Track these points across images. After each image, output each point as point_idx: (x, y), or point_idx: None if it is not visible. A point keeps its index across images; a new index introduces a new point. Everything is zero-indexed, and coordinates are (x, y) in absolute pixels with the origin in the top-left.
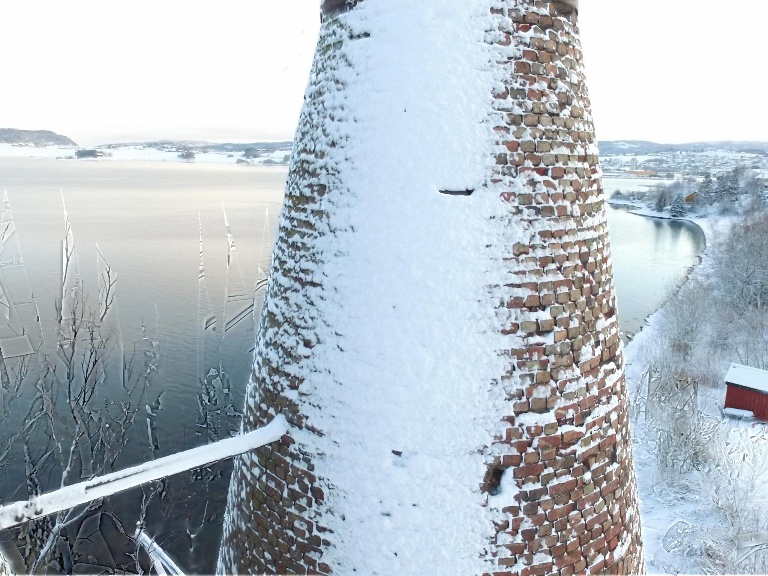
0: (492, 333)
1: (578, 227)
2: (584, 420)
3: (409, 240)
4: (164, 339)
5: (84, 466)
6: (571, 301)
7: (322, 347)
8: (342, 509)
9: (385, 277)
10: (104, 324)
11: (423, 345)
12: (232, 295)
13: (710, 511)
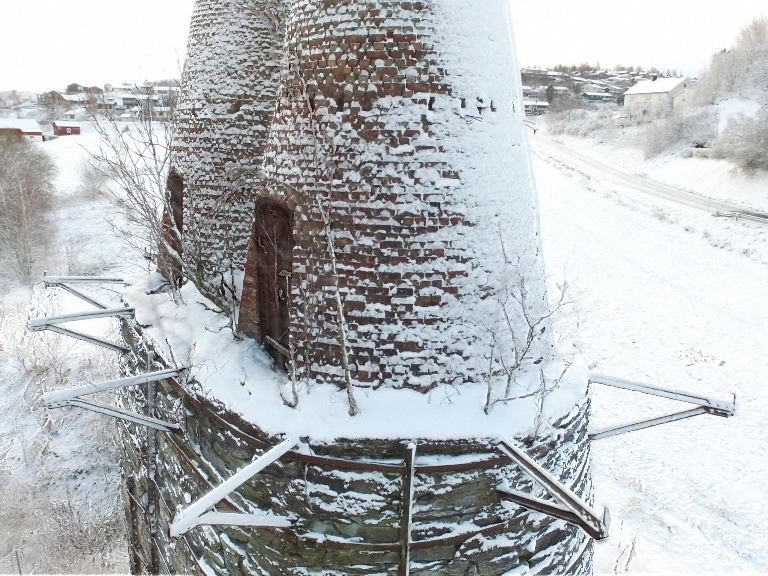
0: None
1: None
2: None
3: None
4: None
5: None
6: None
7: None
8: None
9: None
10: None
11: None
12: None
13: (21, 380)
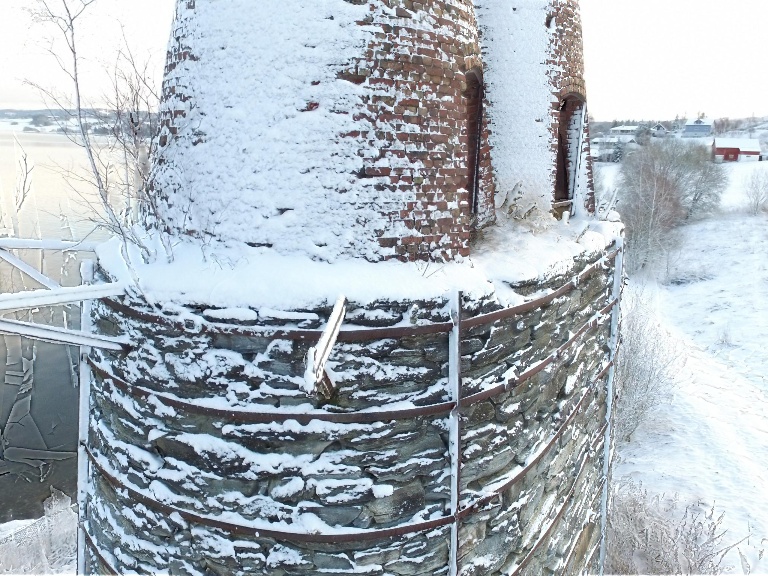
0: None
1: None
2: (574, 10)
3: None
4: (76, 233)
5: (9, 353)
6: None
7: None
8: (492, 36)
9: None
10: (22, 212)
11: None
12: None
13: None
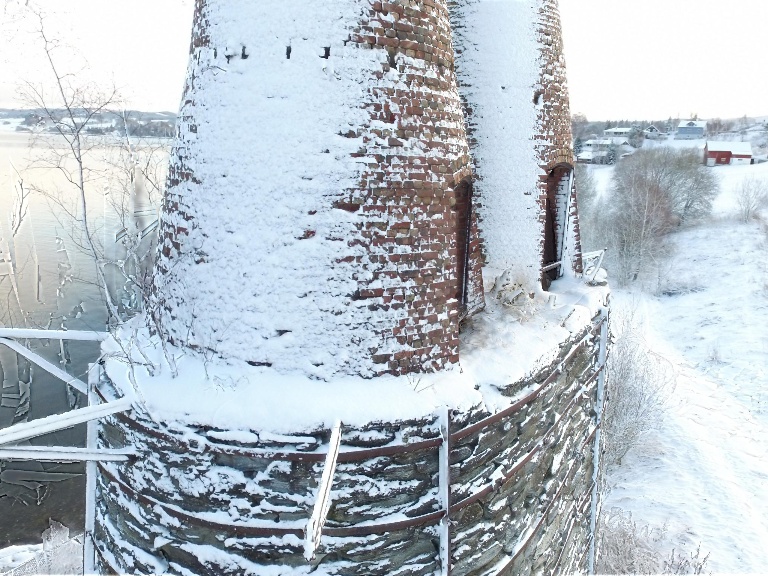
0: (535, 41)
1: (556, 8)
2: (561, 84)
3: (505, 3)
4: (72, 255)
5: (5, 376)
6: (556, 36)
7: (468, 51)
8: (482, 113)
9: (496, 18)
10: (18, 236)
11: (512, 44)
12: (138, 210)
13: None
